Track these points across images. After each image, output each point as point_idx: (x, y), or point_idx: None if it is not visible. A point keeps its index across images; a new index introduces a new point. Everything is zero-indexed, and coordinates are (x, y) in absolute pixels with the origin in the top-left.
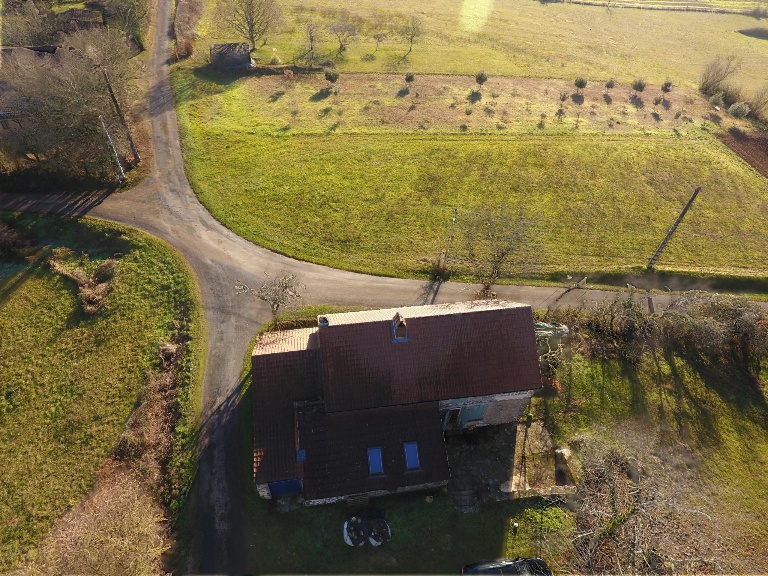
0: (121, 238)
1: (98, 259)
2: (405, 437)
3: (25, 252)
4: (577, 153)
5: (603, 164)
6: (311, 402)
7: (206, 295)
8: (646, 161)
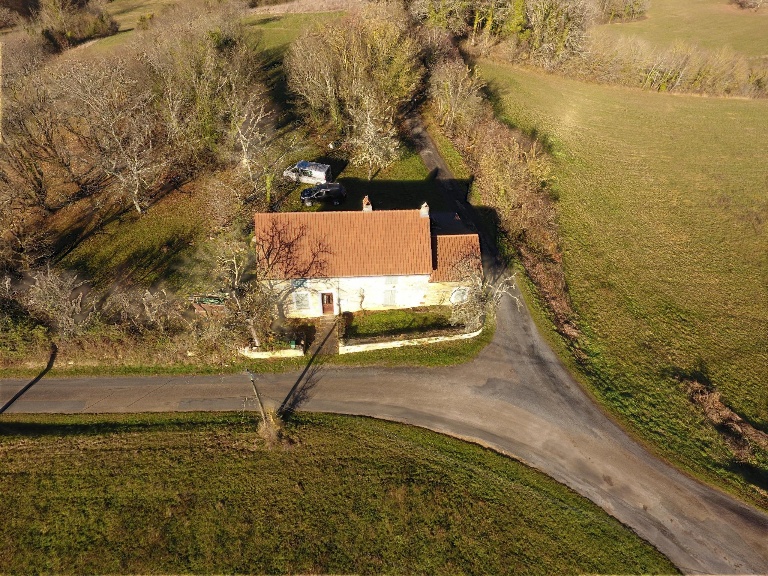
0: None
1: None
2: None
3: None
4: None
5: None
6: None
7: (570, 379)
8: None
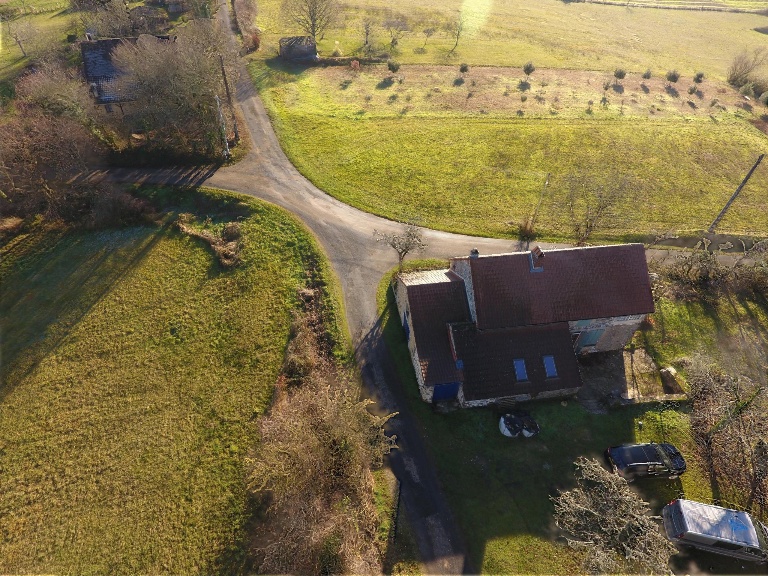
0: (240, 204)
1: (221, 222)
2: (543, 351)
3: (153, 217)
4: (627, 136)
5: (652, 145)
6: (463, 322)
7: (329, 250)
8: (690, 143)
